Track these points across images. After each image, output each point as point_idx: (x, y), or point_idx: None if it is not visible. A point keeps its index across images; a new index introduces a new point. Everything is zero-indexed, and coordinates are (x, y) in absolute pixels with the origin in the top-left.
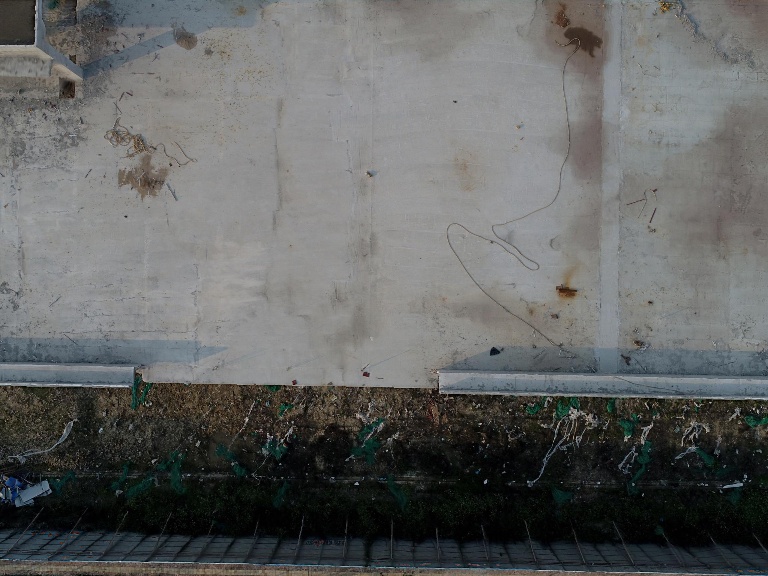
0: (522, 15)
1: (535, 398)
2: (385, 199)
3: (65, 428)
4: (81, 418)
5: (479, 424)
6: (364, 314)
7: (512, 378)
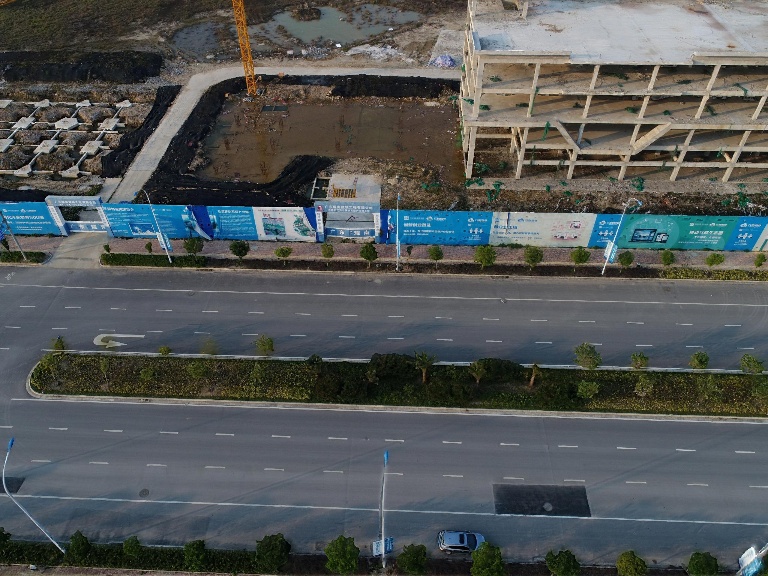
0: (677, 9)
1: (724, 200)
2: (648, 33)
3: (452, 204)
4: (460, 202)
5: (696, 208)
6: (653, 50)
7: None
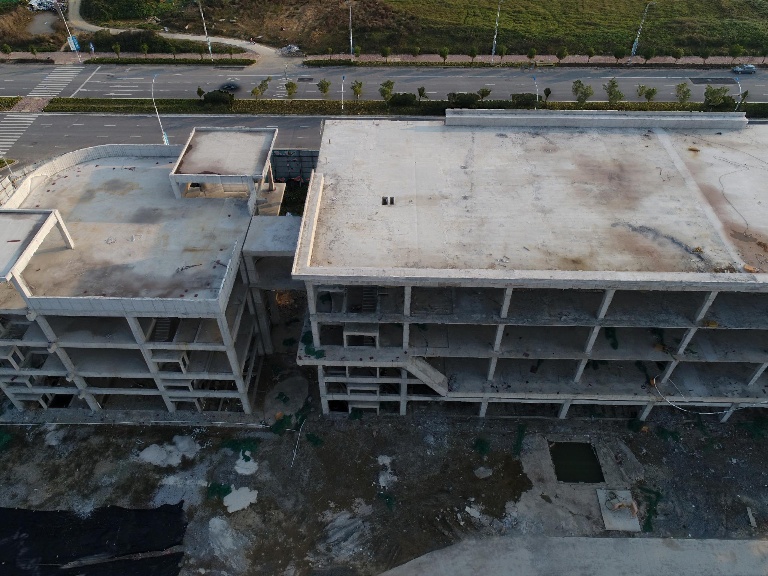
0: None
1: None
2: None
3: None
4: None
5: None
6: None
7: (711, 119)
